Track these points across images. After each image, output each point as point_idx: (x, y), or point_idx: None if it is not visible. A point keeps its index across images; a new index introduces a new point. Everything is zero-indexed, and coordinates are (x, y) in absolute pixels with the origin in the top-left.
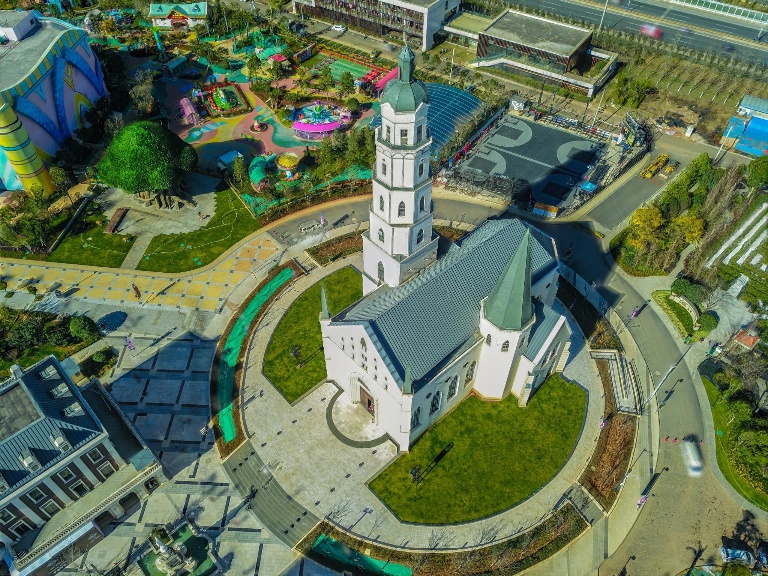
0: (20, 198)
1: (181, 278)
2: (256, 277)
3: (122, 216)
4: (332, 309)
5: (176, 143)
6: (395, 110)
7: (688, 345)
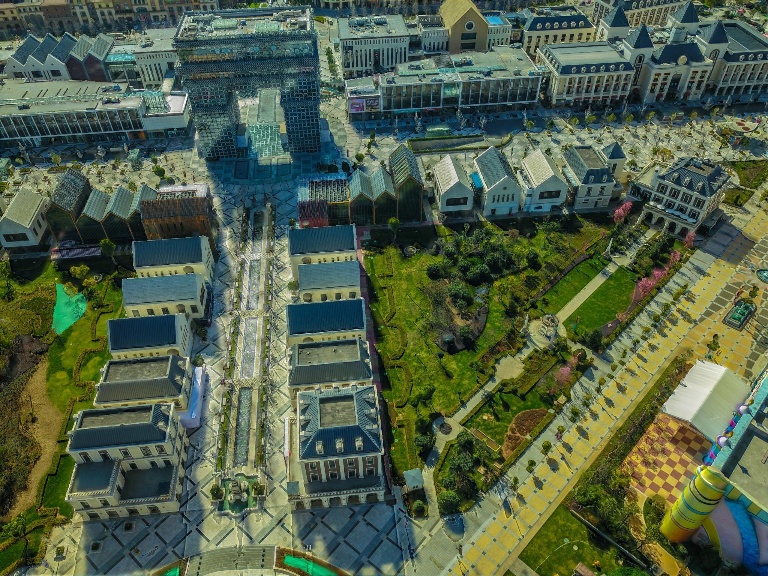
0: (653, 502)
1: None
2: None
3: None
4: None
5: None
6: None
7: None
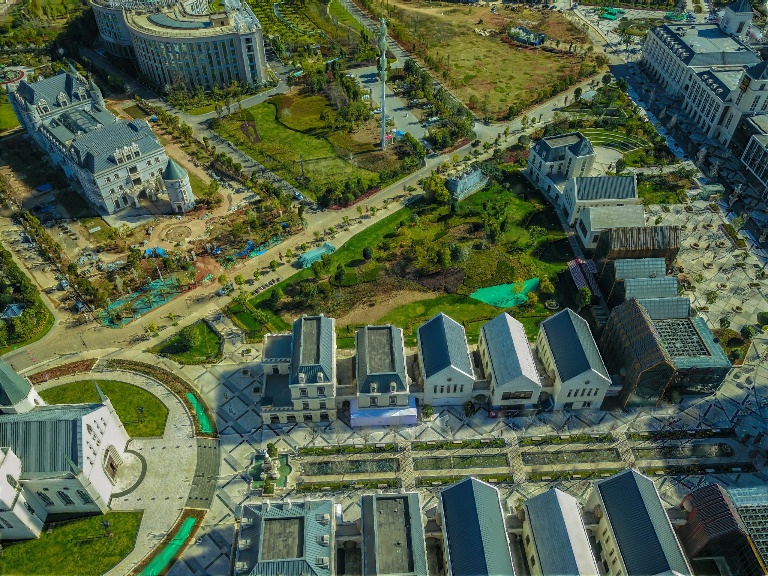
0: None
1: None
2: None
3: None
4: (41, 567)
5: None
6: None
7: None
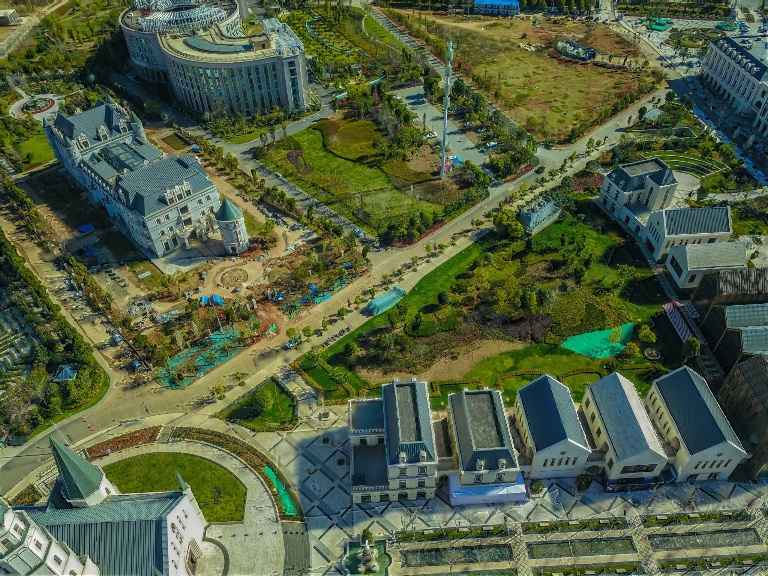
0: None
1: None
2: None
3: None
4: None
5: None
6: (8, 509)
7: (1, 460)
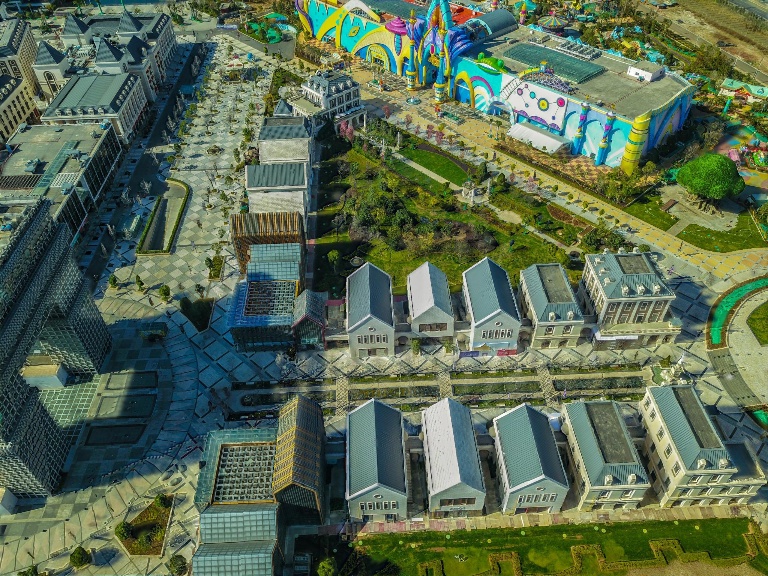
0: None
1: (704, 253)
2: (755, 273)
3: (673, 204)
4: None
5: (737, 175)
6: None
7: None
